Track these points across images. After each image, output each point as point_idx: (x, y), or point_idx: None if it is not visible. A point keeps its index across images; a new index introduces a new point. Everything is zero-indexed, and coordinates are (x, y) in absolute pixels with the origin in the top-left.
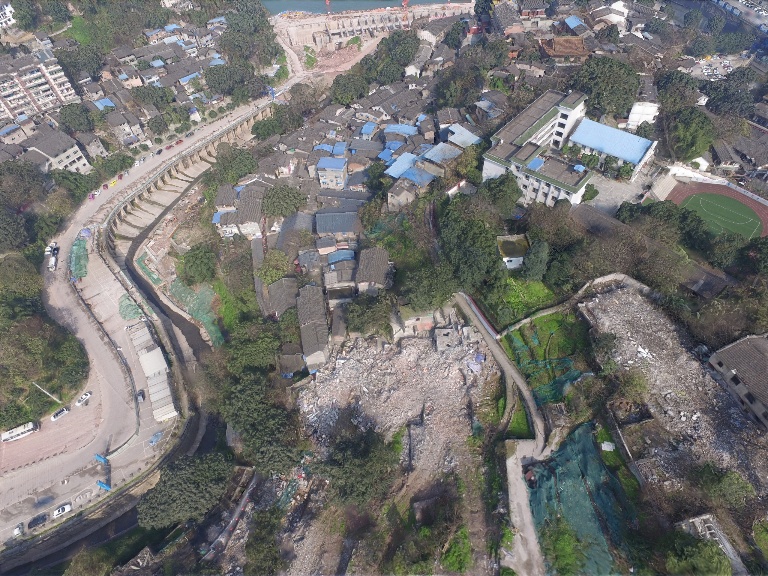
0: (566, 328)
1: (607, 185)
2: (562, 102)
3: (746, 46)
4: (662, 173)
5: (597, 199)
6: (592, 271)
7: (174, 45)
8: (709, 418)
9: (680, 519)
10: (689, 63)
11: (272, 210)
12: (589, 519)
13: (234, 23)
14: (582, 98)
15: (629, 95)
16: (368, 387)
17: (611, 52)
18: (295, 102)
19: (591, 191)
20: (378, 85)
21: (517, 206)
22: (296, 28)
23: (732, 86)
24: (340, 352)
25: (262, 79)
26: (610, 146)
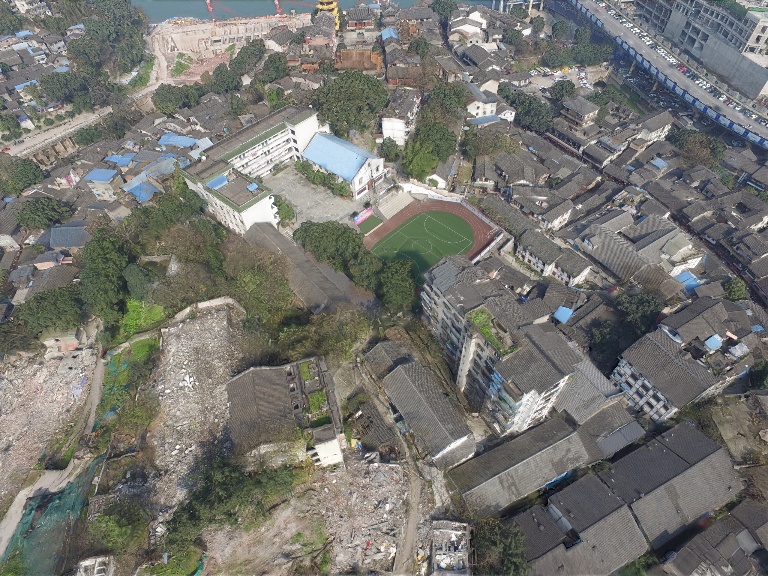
0: (150, 353)
1: (330, 202)
2: (285, 118)
3: (604, 58)
4: (393, 190)
5: (311, 216)
6: (203, 294)
7: (24, 52)
8: (201, 452)
9: (78, 561)
10: (523, 75)
11: (25, 223)
12: (50, 556)
13: (92, 30)
14: (309, 114)
15: (384, 110)
16: (1, 409)
17: (416, 65)
18: (116, 111)
19: (285, 209)
20: (215, 94)
21: (217, 223)
22: (180, 35)
23: (535, 100)
24: (5, 371)
25: (109, 87)
26: (332, 163)
